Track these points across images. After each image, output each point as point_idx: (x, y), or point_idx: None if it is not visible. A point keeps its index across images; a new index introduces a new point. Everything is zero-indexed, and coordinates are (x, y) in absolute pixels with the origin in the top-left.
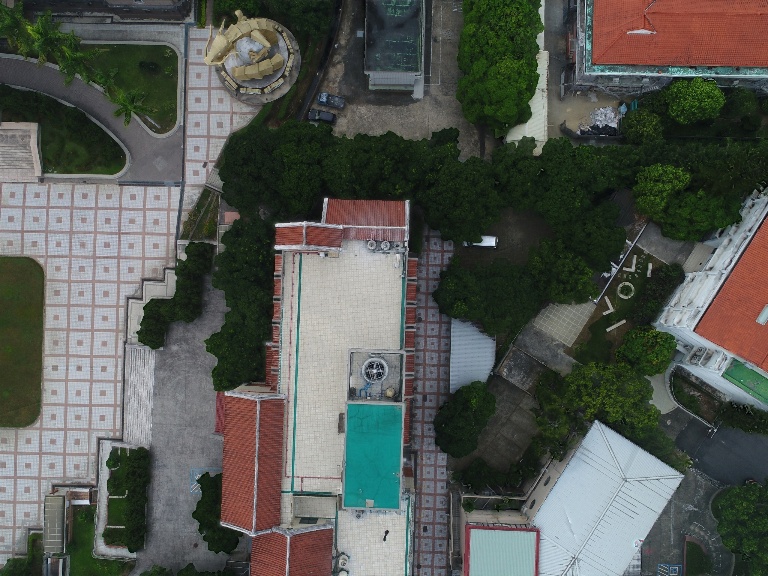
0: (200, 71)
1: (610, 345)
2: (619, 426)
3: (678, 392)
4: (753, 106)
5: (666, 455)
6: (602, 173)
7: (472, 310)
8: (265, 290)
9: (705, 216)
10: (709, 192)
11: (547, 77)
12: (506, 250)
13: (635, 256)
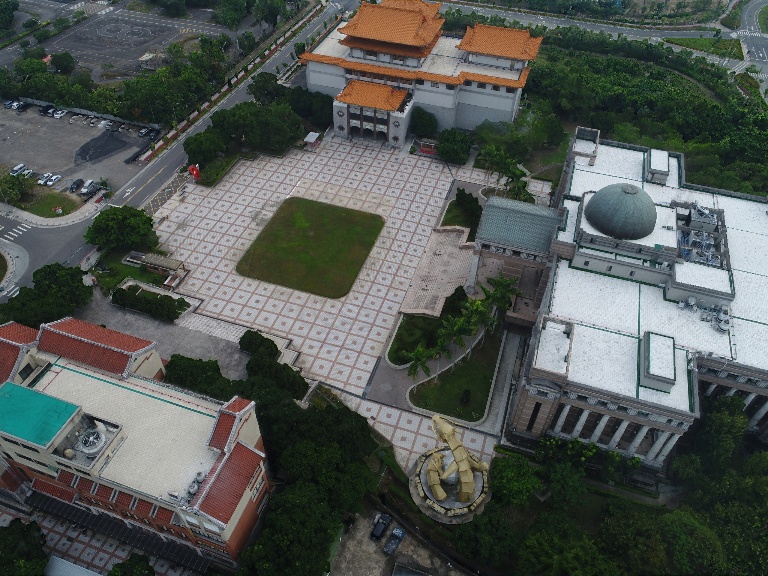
0: None
1: None
2: None
3: None
4: None
5: None
6: None
7: None
8: None
9: None
10: None
11: None
12: None
13: None
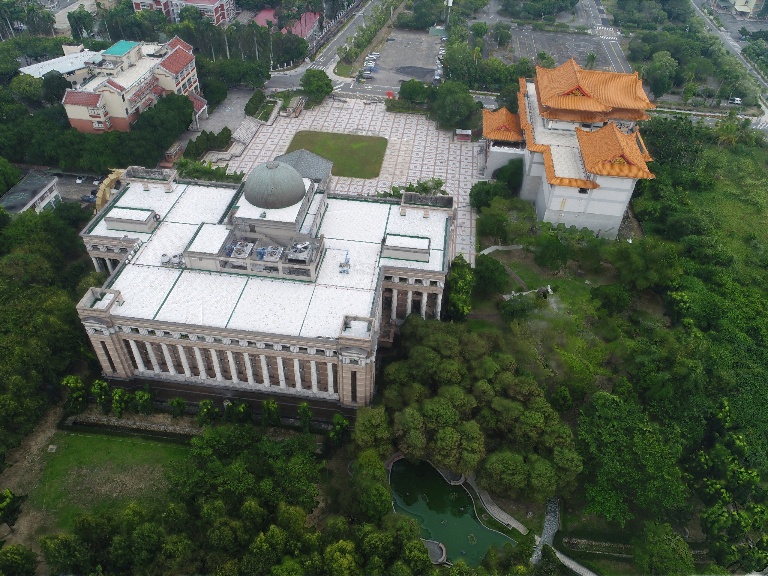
0: None
1: None
2: None
3: None
4: None
5: None
6: None
7: None
8: None
9: None
10: None
11: None
12: None
13: None
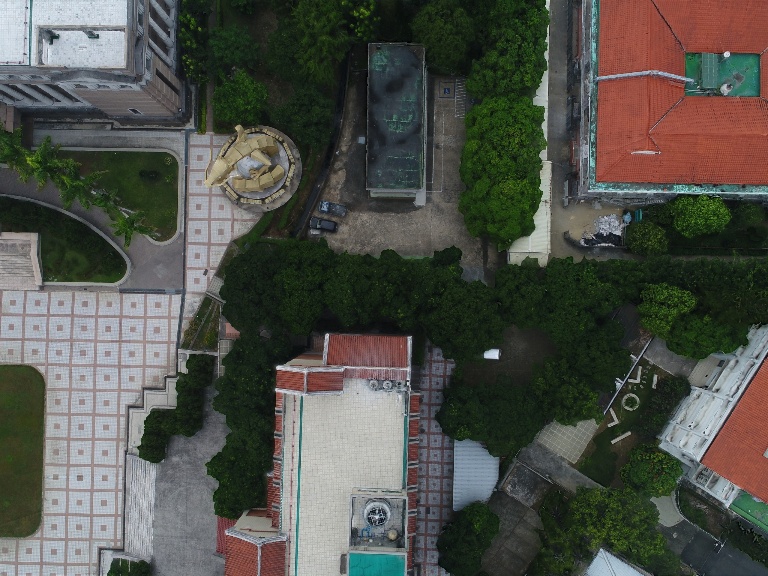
0: (201, 178)
1: (615, 457)
2: (625, 552)
3: (684, 506)
4: (759, 218)
5: (672, 575)
6: (606, 298)
7: (475, 434)
8: (266, 417)
9: (711, 342)
10: (715, 319)
11: (550, 188)
12: (509, 361)
13: (640, 367)
